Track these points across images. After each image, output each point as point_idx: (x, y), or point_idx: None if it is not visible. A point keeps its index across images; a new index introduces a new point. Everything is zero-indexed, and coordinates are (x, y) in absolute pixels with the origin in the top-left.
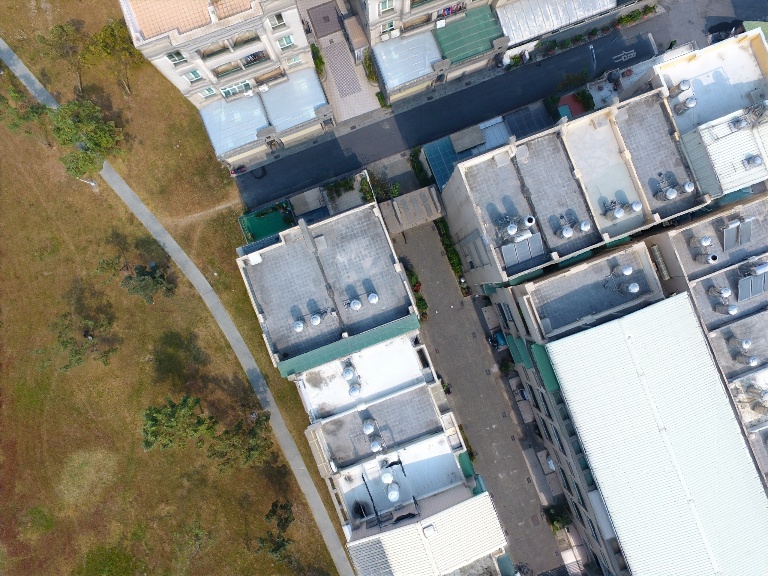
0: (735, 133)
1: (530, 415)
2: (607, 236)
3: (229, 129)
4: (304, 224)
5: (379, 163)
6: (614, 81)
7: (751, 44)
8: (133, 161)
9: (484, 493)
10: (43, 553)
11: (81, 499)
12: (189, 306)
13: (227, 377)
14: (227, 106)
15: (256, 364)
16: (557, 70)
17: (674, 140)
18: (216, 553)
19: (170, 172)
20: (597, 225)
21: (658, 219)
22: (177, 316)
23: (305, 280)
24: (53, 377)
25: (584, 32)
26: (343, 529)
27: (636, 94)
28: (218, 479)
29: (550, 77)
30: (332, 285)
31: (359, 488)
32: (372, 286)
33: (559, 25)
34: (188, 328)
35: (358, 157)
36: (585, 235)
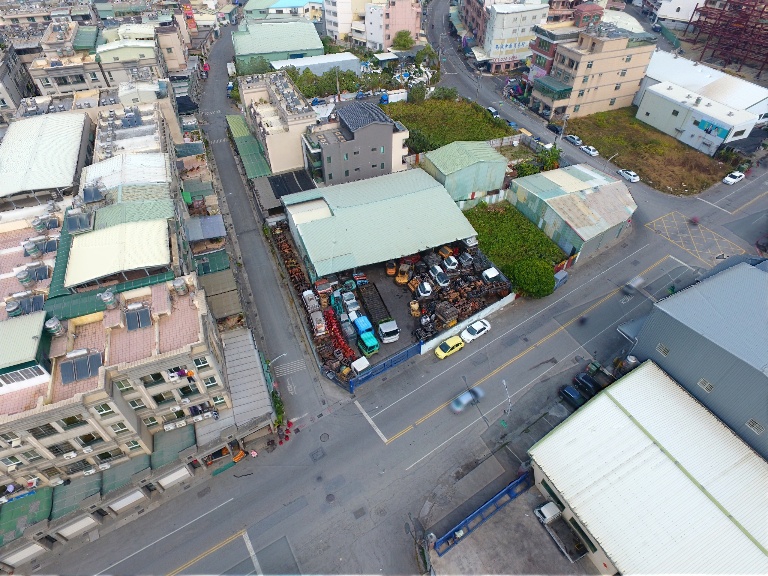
0: None
1: None
2: None
3: None
4: None
5: None
6: None
7: None
8: None
9: None
10: None
11: None
12: None
13: None
14: None
15: None
16: None
17: None
18: None
19: None
20: None
21: None
22: None
23: None
24: None
25: None
26: None
27: None
28: None
29: None
30: None
31: None
32: None
33: None
34: None
35: None
36: None
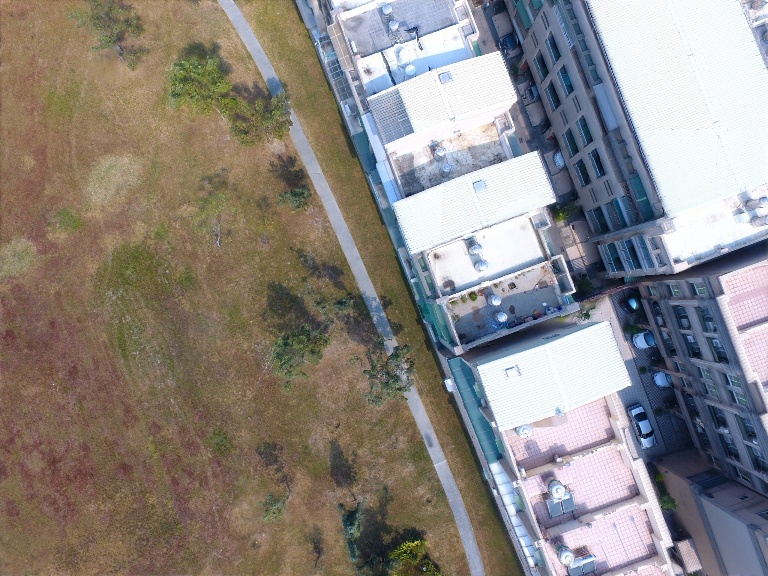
0: None
1: (537, 119)
2: None
3: None
4: None
5: None
6: None
7: None
8: None
9: (496, 52)
10: (71, 251)
11: (107, 200)
12: (212, 18)
13: (248, 86)
14: None
15: (275, 74)
16: None
17: None
18: (235, 252)
19: None
20: None
21: None
22: (201, 28)
23: None
24: (82, 85)
25: None
26: (362, 118)
27: None
28: (238, 182)
29: None
30: None
31: (377, 80)
32: None
33: None
34: (211, 39)
35: None
36: None
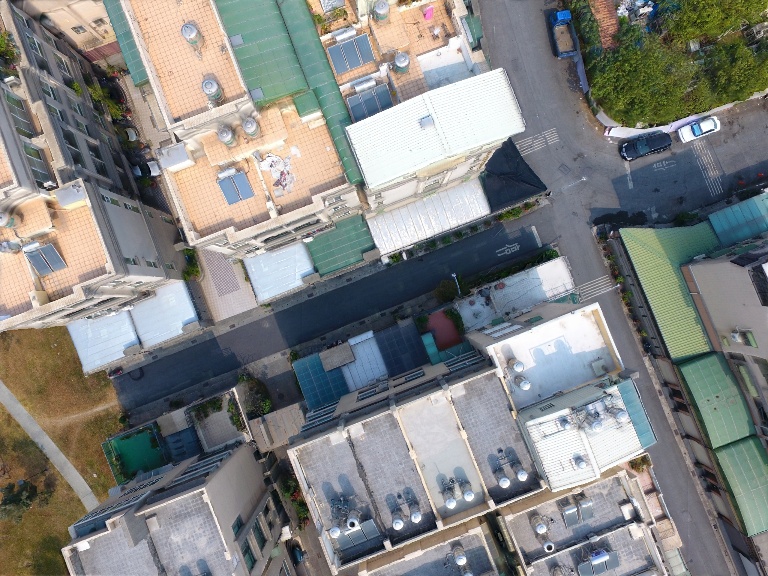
0: (562, 432)
1: None
2: (440, 524)
3: (96, 346)
4: (125, 522)
5: (259, 362)
6: (485, 296)
7: (593, 312)
8: (10, 360)
9: None
10: None
11: None
12: (68, 510)
13: None
14: (93, 322)
15: None
16: (439, 265)
17: (512, 417)
18: None
19: (48, 372)
20: (433, 508)
21: (493, 506)
22: (55, 520)
23: (138, 562)
24: None
25: (466, 227)
26: None
27: (475, 366)
28: None
29: (432, 272)
30: (165, 566)
31: None
32: (206, 567)
33: (432, 234)
34: (67, 532)
35: (237, 357)
36: (423, 514)
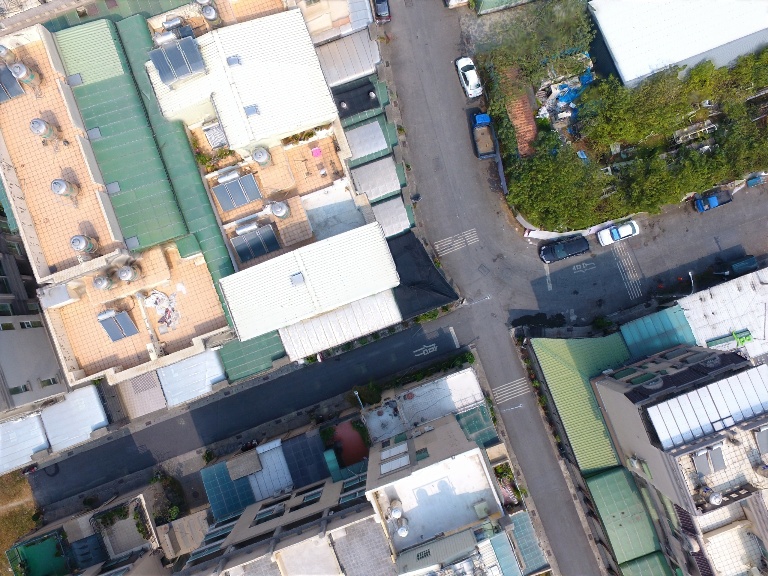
0: None
1: None
2: None
3: (4, 449)
4: None
5: (174, 460)
6: None
7: None
8: None
9: None
10: None
11: None
12: None
13: None
14: (2, 426)
15: None
16: (357, 364)
17: None
18: None
19: None
20: None
21: None
22: None
23: None
24: None
25: None
26: None
27: (357, 507)
28: None
29: (349, 372)
30: None
31: None
32: None
33: (343, 341)
34: None
35: (153, 454)
36: None
